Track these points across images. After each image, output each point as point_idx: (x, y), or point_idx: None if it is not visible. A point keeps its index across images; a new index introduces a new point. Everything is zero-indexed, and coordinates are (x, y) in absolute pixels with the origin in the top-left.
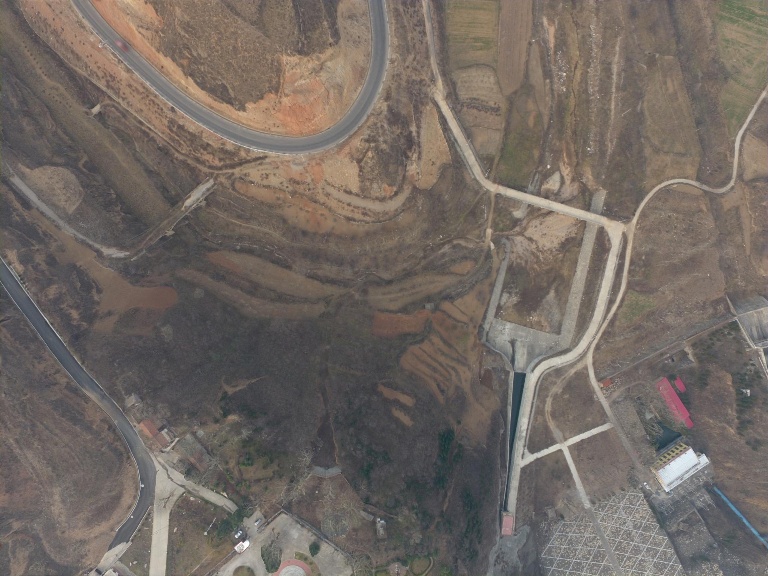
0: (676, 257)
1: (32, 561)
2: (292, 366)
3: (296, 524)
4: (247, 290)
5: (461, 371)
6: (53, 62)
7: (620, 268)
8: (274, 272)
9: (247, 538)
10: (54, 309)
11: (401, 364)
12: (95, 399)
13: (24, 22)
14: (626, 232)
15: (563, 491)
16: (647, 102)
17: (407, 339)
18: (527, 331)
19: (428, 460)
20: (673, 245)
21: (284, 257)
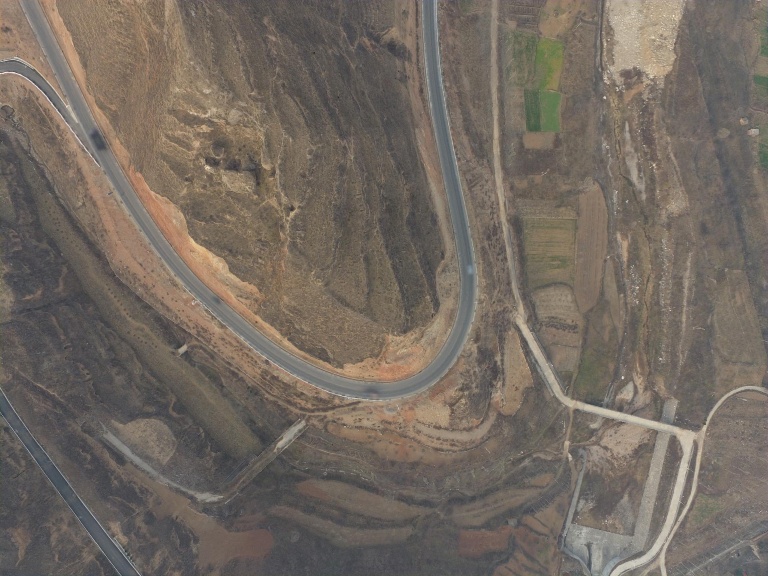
0: (744, 464)
1: None
2: None
3: None
4: (337, 519)
5: None
6: (138, 304)
7: (691, 473)
8: (361, 496)
9: None
10: None
11: None
12: None
13: (107, 265)
14: (697, 440)
15: None
16: (717, 315)
17: (493, 559)
18: (602, 534)
19: None
20: (740, 449)
21: (370, 480)
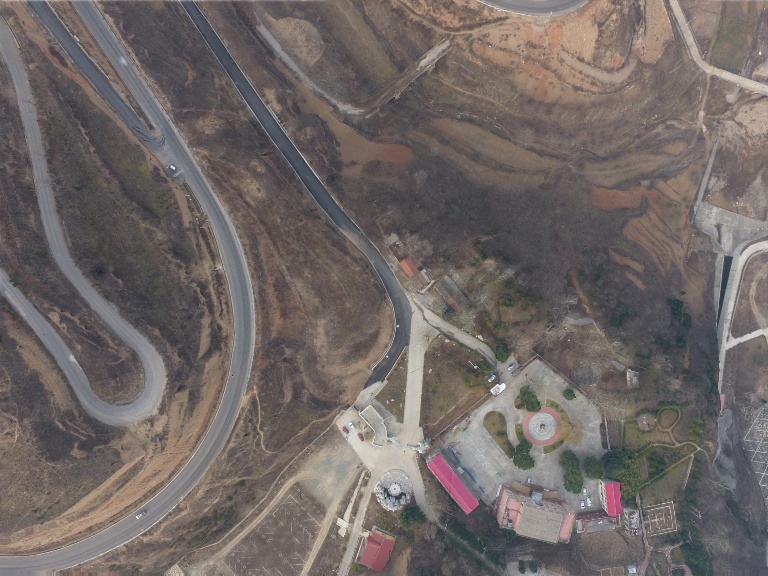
0: None
1: (296, 392)
2: (529, 225)
3: (550, 370)
4: (470, 157)
5: (675, 248)
6: None
7: None
8: (494, 142)
9: (502, 382)
10: (311, 149)
11: (625, 234)
12: (352, 239)
13: None
14: None
15: (764, 377)
16: None
17: (627, 212)
18: (733, 216)
19: (666, 320)
20: None
21: (503, 129)
